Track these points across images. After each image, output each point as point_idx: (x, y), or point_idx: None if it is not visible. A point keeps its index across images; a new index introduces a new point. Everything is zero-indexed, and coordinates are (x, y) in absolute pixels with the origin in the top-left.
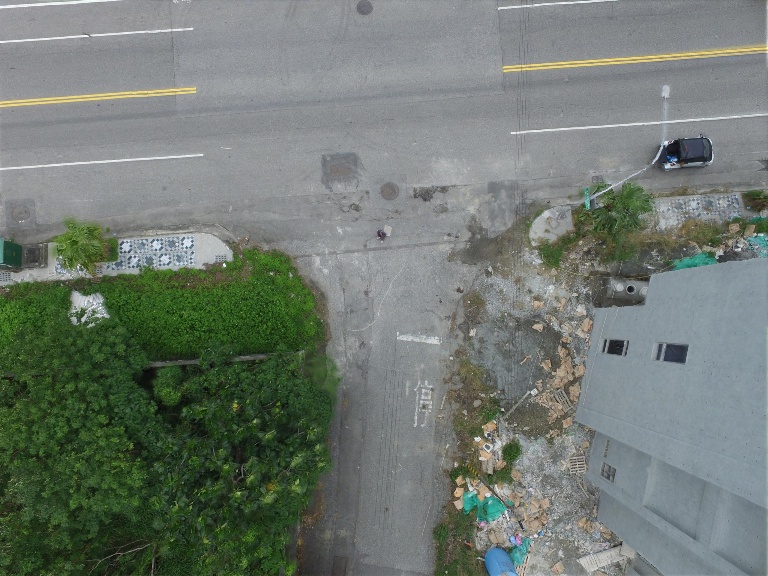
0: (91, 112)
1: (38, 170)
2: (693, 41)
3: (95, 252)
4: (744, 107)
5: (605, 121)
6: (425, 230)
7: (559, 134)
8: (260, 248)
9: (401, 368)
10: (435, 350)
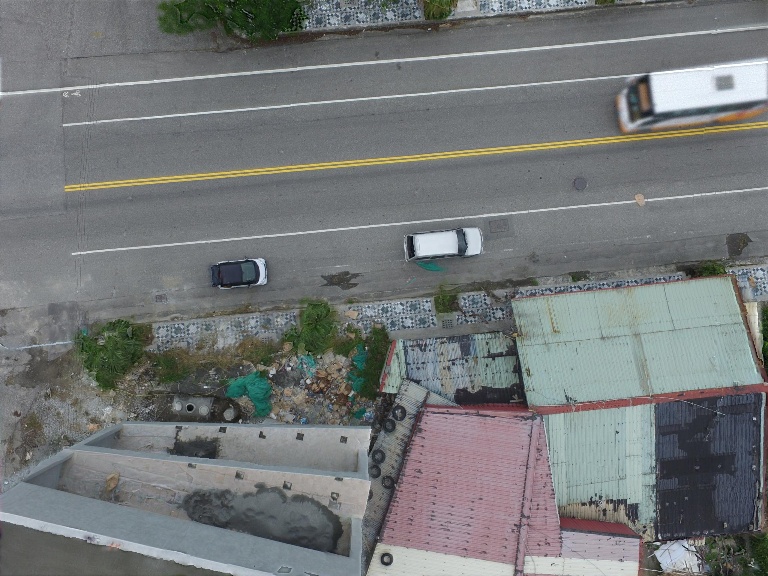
0: None
1: None
2: (258, 157)
3: None
4: (307, 223)
5: (168, 239)
6: None
7: (122, 253)
8: None
9: None
10: None
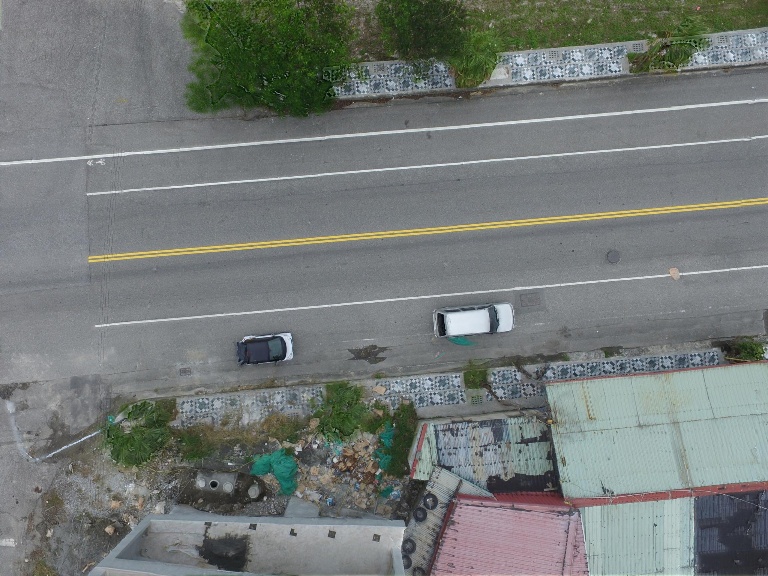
0: None
1: None
2: (285, 227)
3: None
4: (334, 296)
5: (193, 312)
6: (3, 429)
7: (146, 326)
8: None
9: None
10: (9, 553)
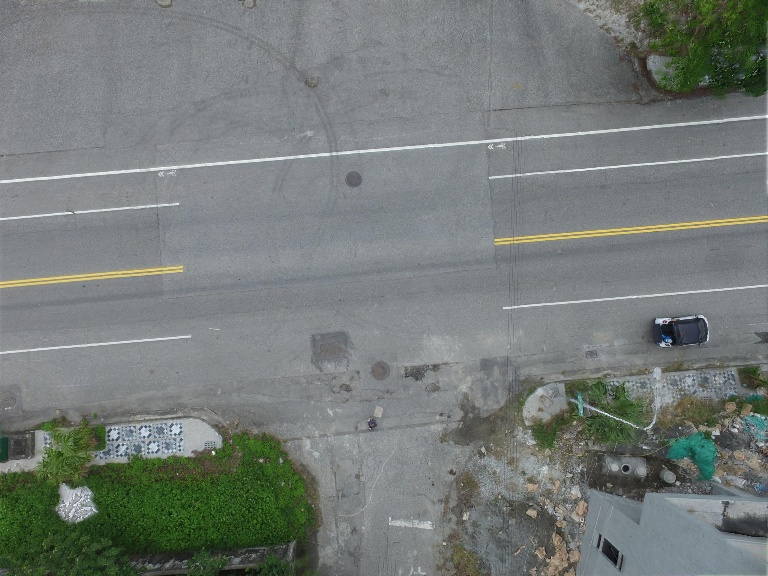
0: (76, 294)
1: (23, 355)
2: (688, 210)
3: (81, 463)
4: (740, 278)
5: (599, 294)
6: (417, 410)
7: (552, 308)
8: (250, 432)
9: (394, 555)
10: (428, 535)
